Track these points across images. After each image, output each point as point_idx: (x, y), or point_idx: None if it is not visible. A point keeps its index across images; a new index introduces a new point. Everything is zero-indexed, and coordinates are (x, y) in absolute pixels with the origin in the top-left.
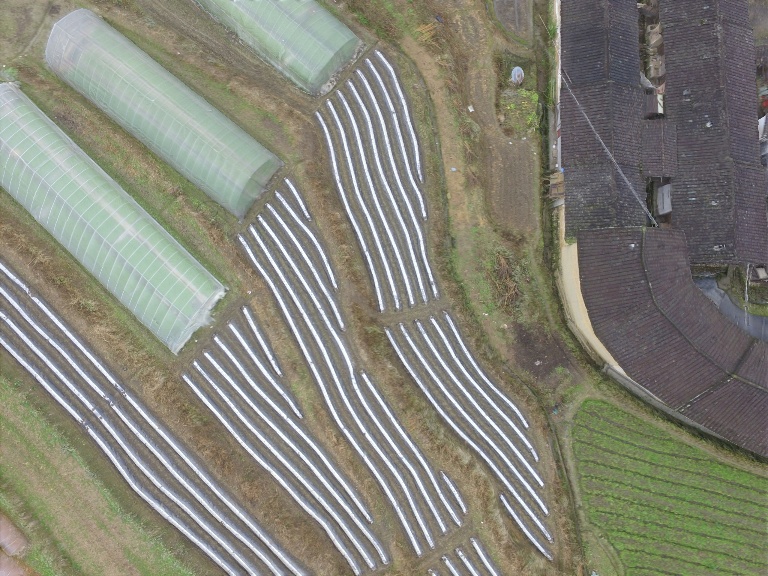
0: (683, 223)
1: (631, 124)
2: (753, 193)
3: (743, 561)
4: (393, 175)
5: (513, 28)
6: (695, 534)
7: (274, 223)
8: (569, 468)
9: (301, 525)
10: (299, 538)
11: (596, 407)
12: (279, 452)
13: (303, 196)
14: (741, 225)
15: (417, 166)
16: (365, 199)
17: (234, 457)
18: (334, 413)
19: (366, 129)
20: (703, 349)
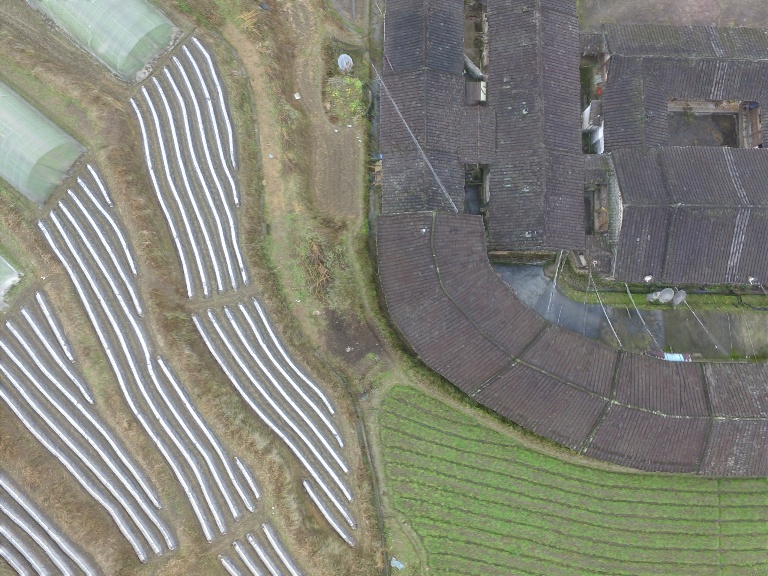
0: (499, 210)
1: (448, 111)
2: (569, 180)
3: (547, 547)
4: (206, 162)
5: (349, 16)
6: (500, 520)
7: (76, 209)
8: (374, 454)
9: (85, 510)
10: (80, 523)
11: (403, 393)
12: (68, 438)
13: (105, 182)
14: (553, 211)
15: (230, 153)
16: (178, 186)
17: (20, 442)
18: (128, 399)
19: (181, 116)
20: (490, 334)
